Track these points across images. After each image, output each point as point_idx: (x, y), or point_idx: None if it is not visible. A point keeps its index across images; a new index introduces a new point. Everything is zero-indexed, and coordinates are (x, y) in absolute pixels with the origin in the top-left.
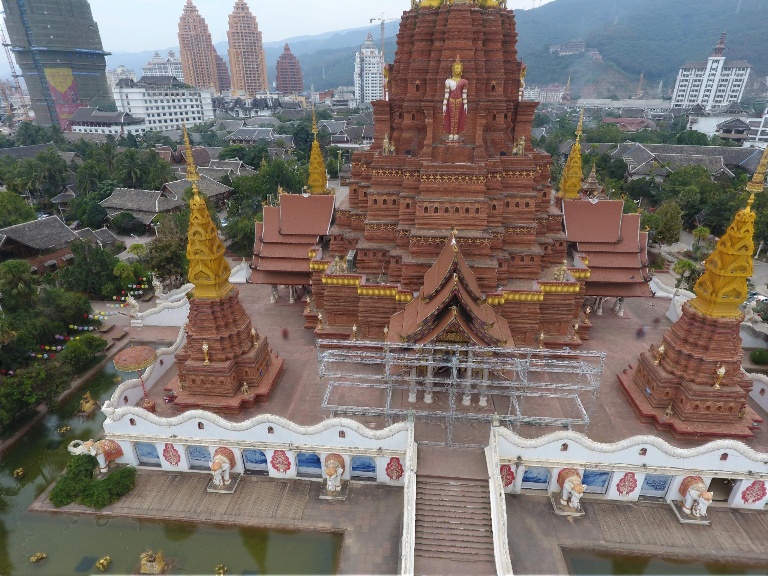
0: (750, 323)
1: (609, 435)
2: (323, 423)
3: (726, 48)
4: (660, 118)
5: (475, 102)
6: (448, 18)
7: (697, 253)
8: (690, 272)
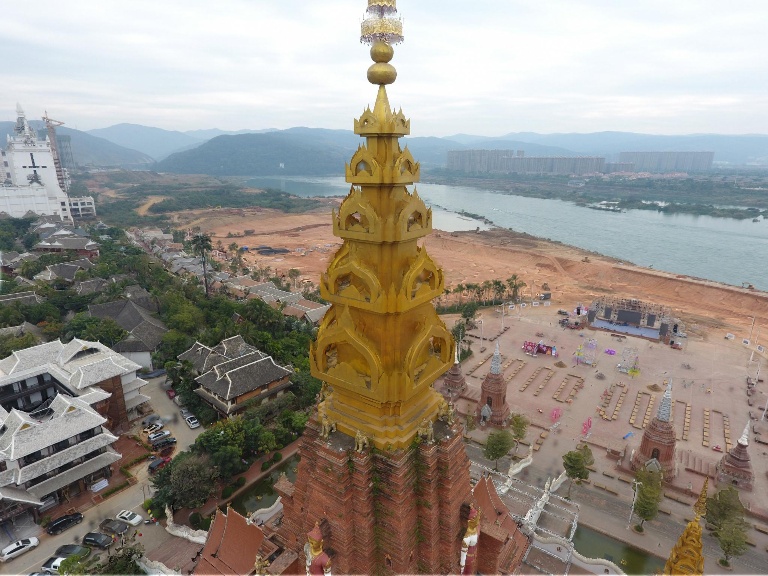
0: None
1: None
2: None
3: None
4: None
5: None
6: None
7: None
8: None
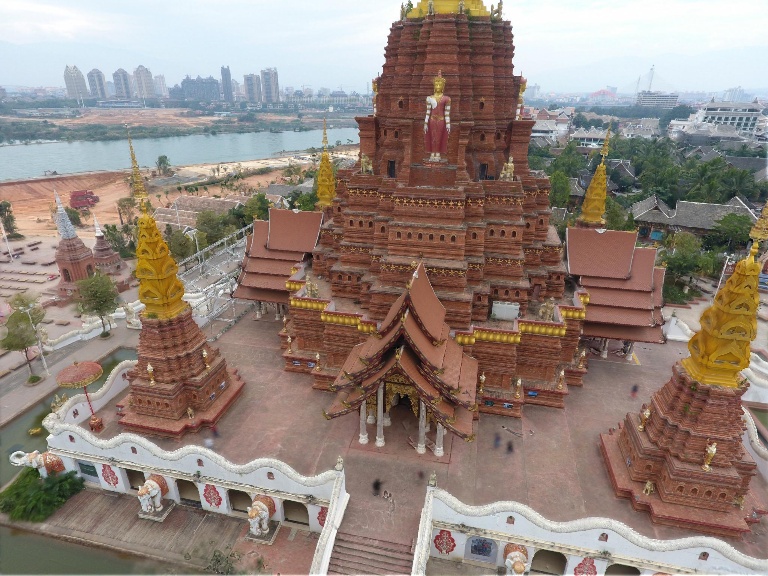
0: None
1: None
2: None
3: None
4: None
5: None
6: None
7: None
8: None
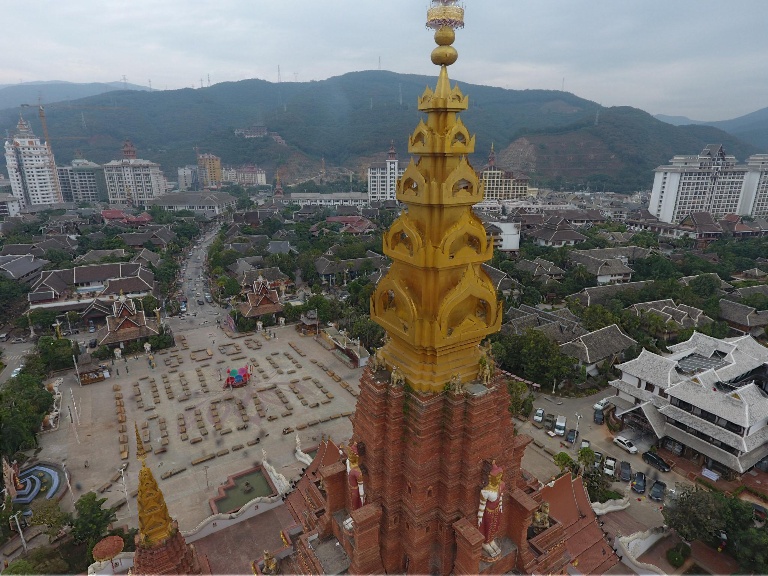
0: (628, 503)
1: None
2: None
3: (397, 153)
4: (374, 216)
5: (506, 494)
6: (473, 417)
7: (526, 409)
8: (572, 467)
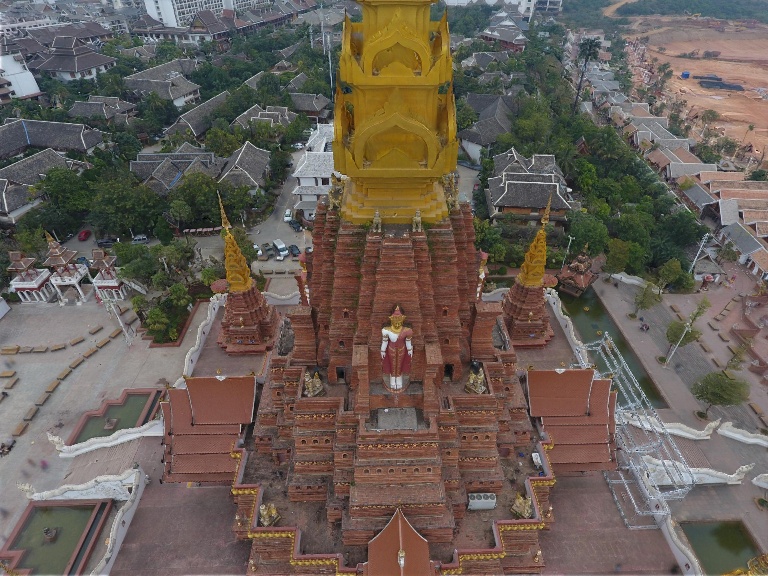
0: None
1: None
2: None
3: None
4: None
5: None
6: None
7: None
8: None
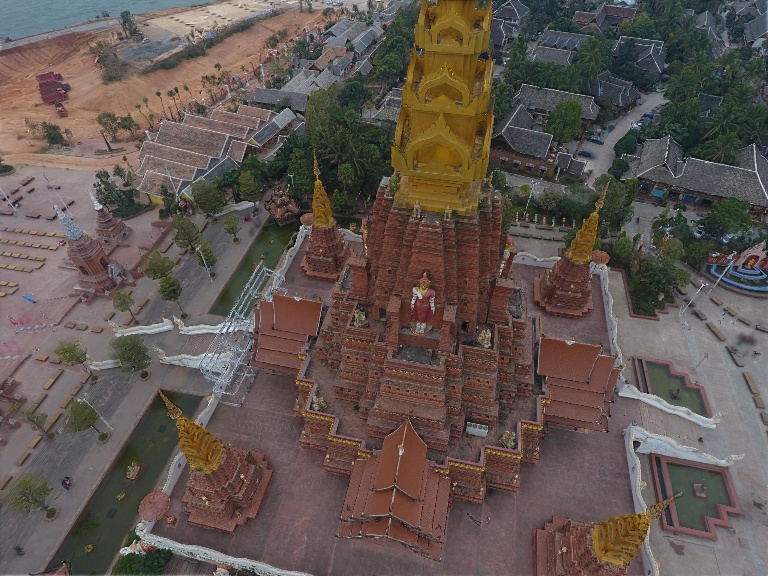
0: None
1: (226, 424)
2: (268, 291)
3: None
4: None
5: None
6: None
7: None
8: None
